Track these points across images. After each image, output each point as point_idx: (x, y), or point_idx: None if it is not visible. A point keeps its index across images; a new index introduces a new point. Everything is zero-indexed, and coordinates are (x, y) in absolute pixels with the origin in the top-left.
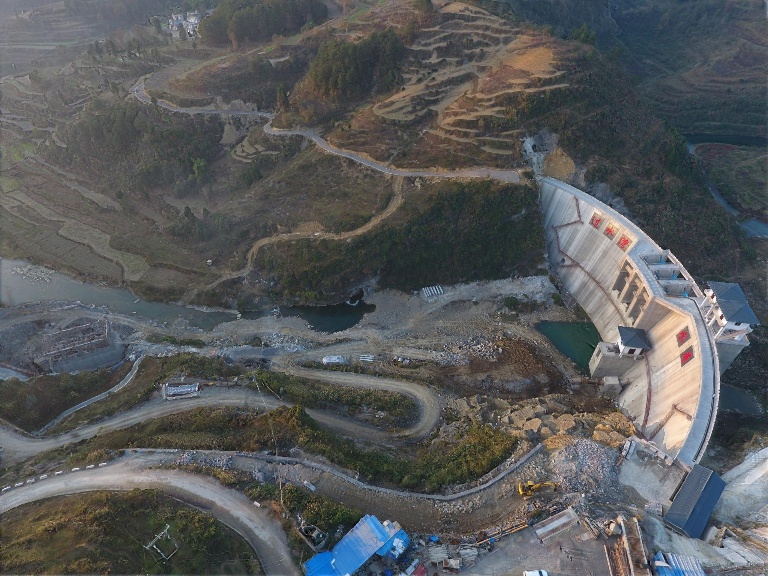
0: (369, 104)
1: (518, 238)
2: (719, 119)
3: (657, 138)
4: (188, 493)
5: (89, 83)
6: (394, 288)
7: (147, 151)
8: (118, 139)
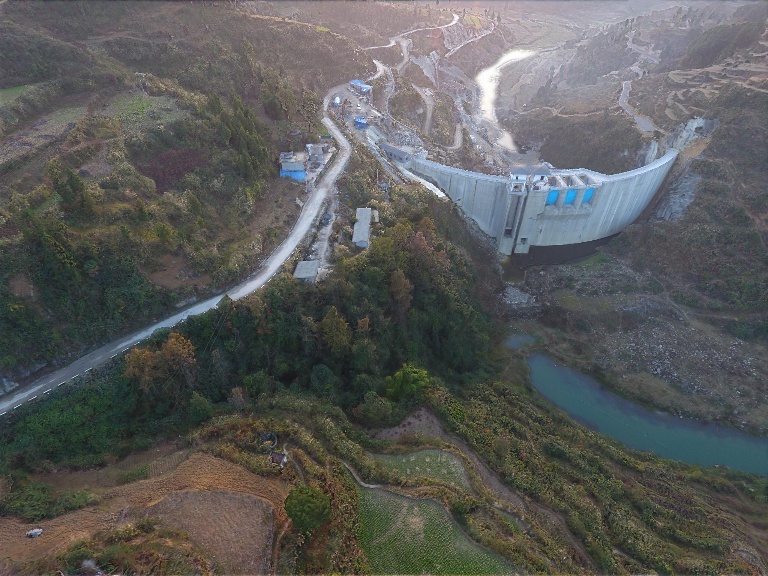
0: None
1: (608, 169)
2: None
3: None
4: (377, 73)
5: None
6: None
7: None
8: None
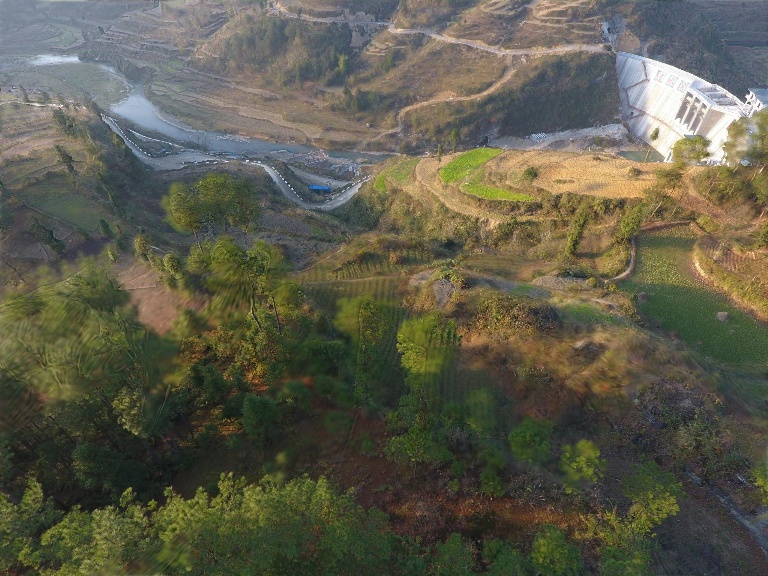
0: (473, 7)
1: (600, 95)
2: (735, 28)
3: (697, 25)
4: None
5: (216, 10)
6: (511, 135)
7: (295, 53)
8: (269, 45)
